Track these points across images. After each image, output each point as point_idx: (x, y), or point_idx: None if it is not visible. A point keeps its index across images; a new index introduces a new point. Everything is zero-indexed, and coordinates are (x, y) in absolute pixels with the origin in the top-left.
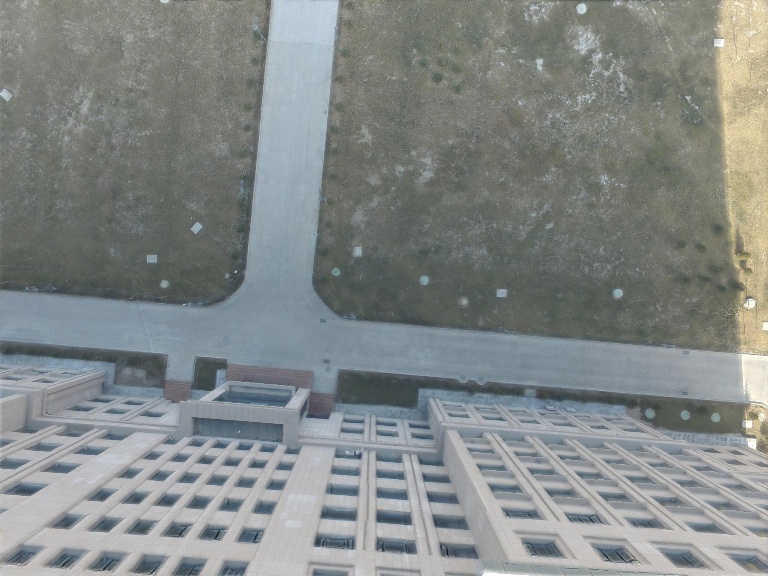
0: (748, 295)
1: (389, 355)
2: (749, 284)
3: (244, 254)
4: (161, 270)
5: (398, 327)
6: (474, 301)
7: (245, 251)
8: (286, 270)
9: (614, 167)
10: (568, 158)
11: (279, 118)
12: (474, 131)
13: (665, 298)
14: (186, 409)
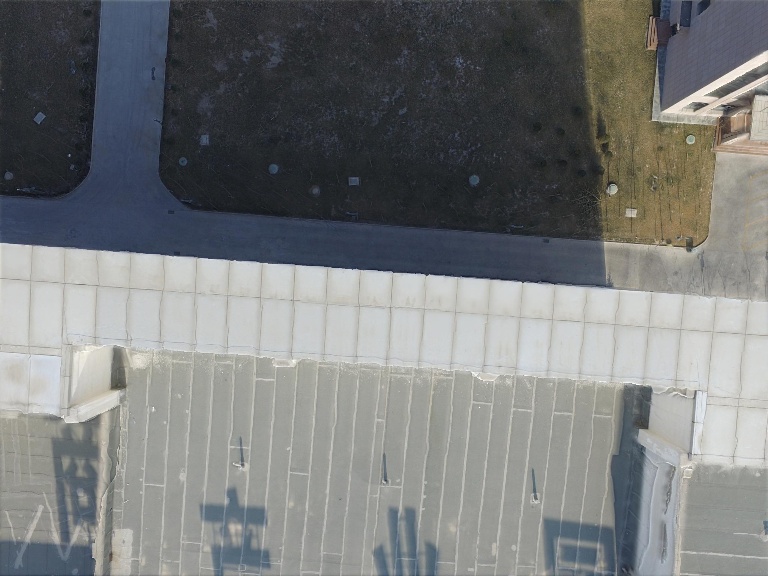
0: (610, 180)
1: (240, 246)
2: (611, 169)
3: (88, 144)
4: (5, 162)
5: (248, 218)
6: (326, 190)
7: (89, 141)
8: (132, 160)
9: (469, 49)
10: (421, 40)
11: (120, 3)
12: (323, 13)
13: (524, 185)
14: None
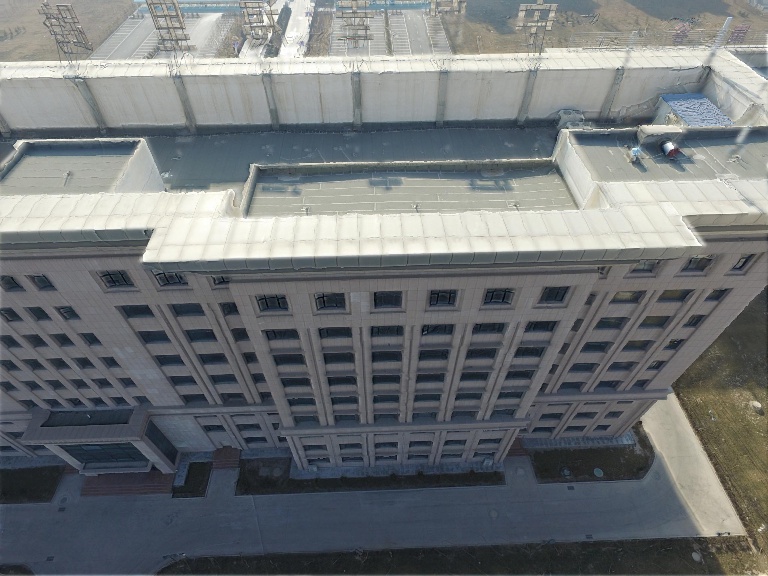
0: None
1: None
2: None
3: None
4: None
5: None
6: None
7: None
8: None
9: None
10: None
11: None
12: None
13: None
14: (132, 431)
